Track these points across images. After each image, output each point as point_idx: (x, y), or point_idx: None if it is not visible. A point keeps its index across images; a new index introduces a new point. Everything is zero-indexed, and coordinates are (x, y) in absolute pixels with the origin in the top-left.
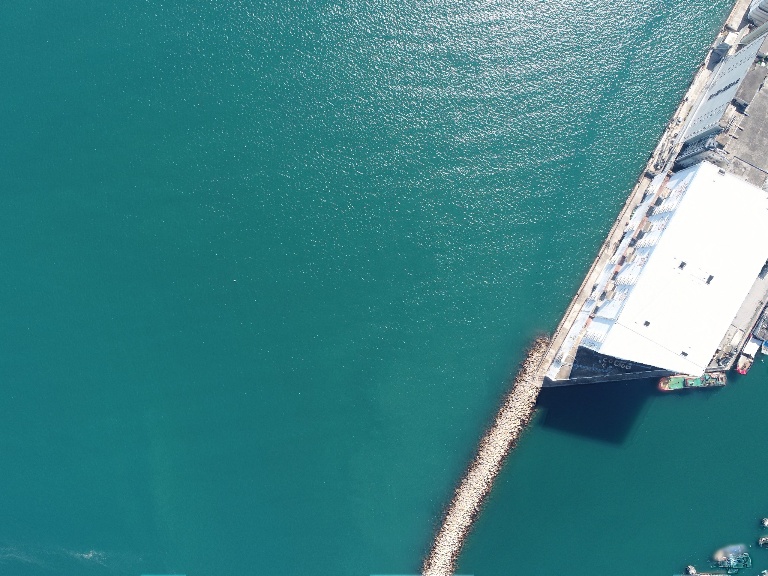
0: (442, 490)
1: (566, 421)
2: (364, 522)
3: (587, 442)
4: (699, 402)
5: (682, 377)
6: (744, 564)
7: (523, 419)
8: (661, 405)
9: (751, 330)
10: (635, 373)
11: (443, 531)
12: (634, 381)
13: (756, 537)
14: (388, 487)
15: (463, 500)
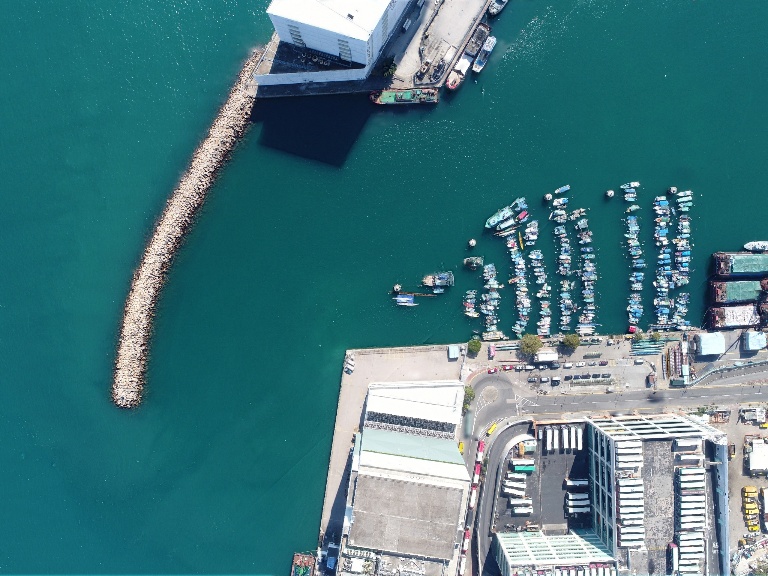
0: (155, 202)
1: (281, 136)
2: (74, 231)
3: (300, 156)
4: (412, 120)
5: (394, 91)
6: (447, 281)
7: (237, 130)
8: (375, 122)
9: (464, 48)
10: (348, 86)
11: (153, 241)
12: (348, 95)
13: (462, 257)
14: (102, 199)
15: (172, 209)
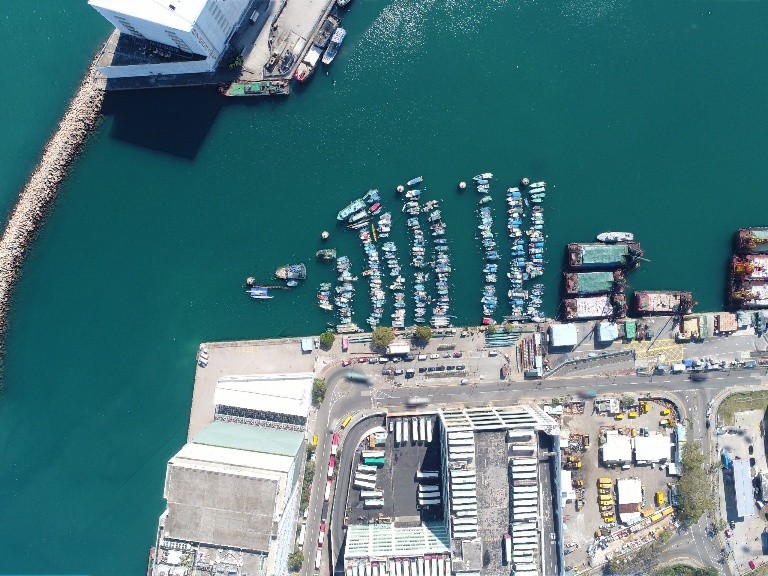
0: (8, 196)
1: (133, 129)
2: None
3: (152, 149)
4: (264, 113)
5: (243, 83)
6: (299, 274)
7: (87, 123)
8: (226, 114)
9: None
10: (198, 78)
11: (5, 235)
12: (198, 88)
13: (315, 249)
14: None
15: (23, 202)
